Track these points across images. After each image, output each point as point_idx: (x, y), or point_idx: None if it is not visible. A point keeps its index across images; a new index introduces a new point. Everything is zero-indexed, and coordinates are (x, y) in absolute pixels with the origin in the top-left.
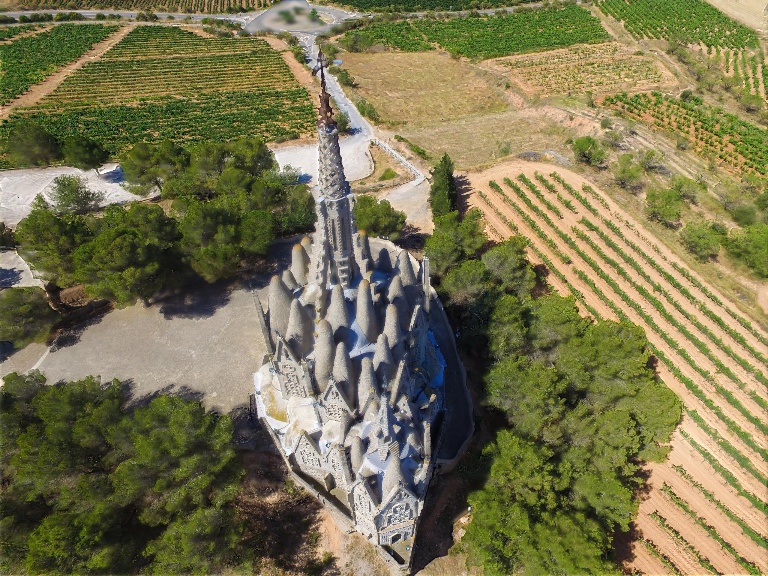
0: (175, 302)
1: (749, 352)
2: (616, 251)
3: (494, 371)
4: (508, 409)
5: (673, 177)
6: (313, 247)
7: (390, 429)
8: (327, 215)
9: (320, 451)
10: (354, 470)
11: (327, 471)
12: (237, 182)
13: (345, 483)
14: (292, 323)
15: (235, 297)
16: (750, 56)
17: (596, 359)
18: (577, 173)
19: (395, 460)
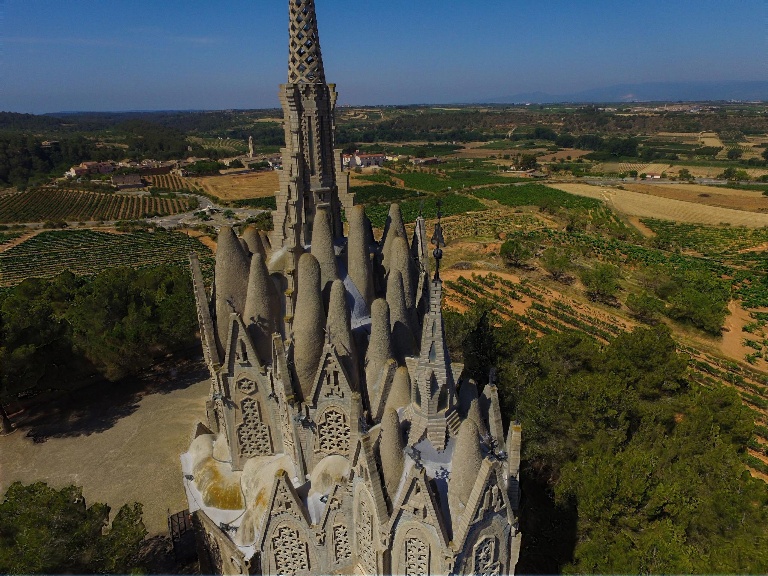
0: (54, 421)
1: (752, 392)
2: (576, 325)
3: (522, 401)
4: (554, 455)
5: (596, 264)
6: (277, 192)
7: (446, 370)
8: (302, 109)
9: (310, 520)
10: (389, 491)
11: (321, 575)
12: (154, 285)
13: (364, 567)
14: (252, 295)
15: (148, 401)
16: (603, 205)
17: (630, 375)
18: (510, 274)
19: (468, 422)
